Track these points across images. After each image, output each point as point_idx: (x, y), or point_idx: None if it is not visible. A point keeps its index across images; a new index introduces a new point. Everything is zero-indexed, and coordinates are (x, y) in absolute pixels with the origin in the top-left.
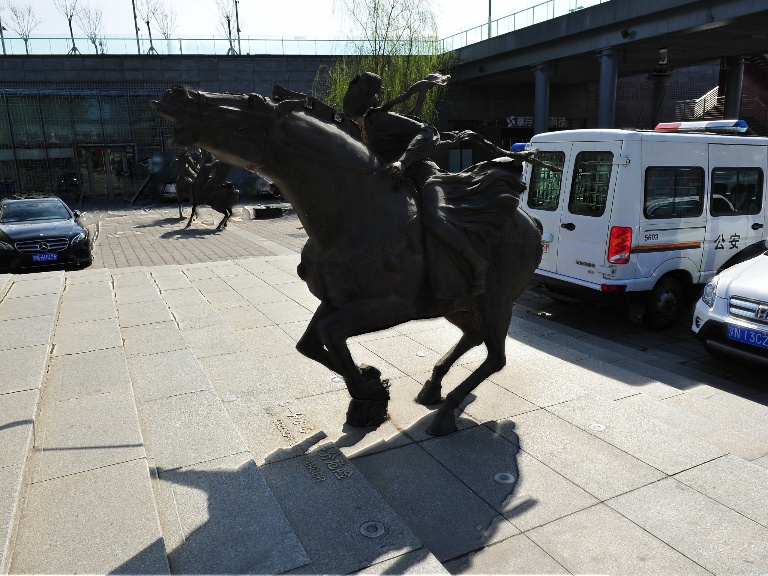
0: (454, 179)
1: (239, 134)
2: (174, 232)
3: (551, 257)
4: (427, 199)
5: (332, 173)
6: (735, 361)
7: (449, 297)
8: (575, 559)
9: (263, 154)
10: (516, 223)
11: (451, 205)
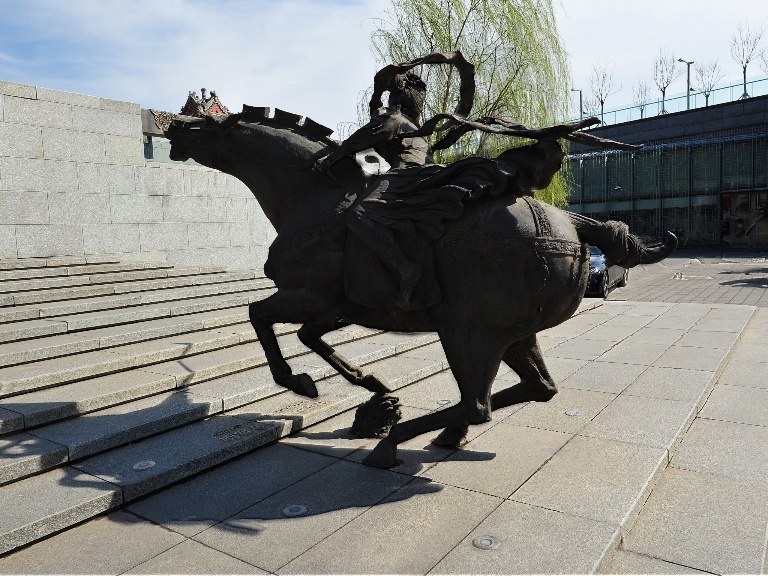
0: (413, 171)
1: (198, 146)
2: (747, 280)
3: None
4: (362, 194)
5: (265, 172)
6: None
7: (369, 304)
8: (146, 572)
9: (212, 160)
10: (476, 224)
11: (385, 200)
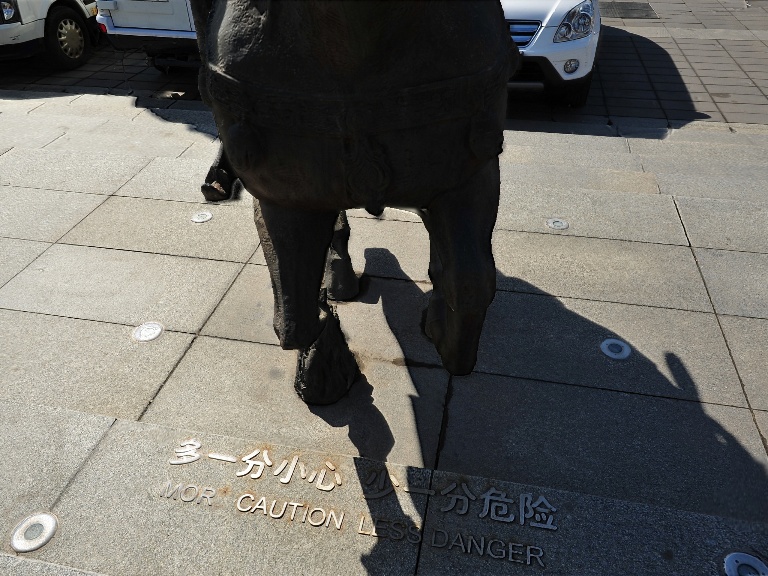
0: None
1: None
2: None
3: (176, 7)
4: None
5: None
6: None
7: None
8: None
9: None
10: None
11: None
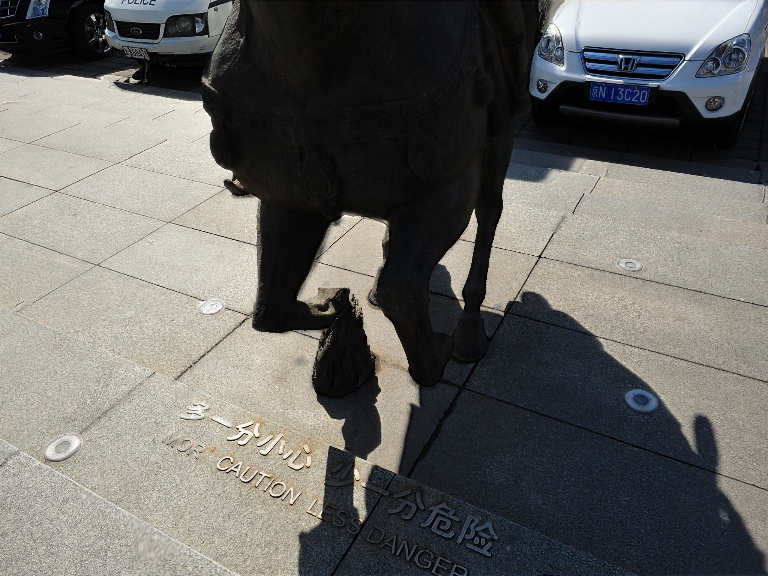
0: None
1: None
2: None
3: None
4: None
5: None
6: (559, 122)
7: None
8: None
9: None
10: None
11: None
